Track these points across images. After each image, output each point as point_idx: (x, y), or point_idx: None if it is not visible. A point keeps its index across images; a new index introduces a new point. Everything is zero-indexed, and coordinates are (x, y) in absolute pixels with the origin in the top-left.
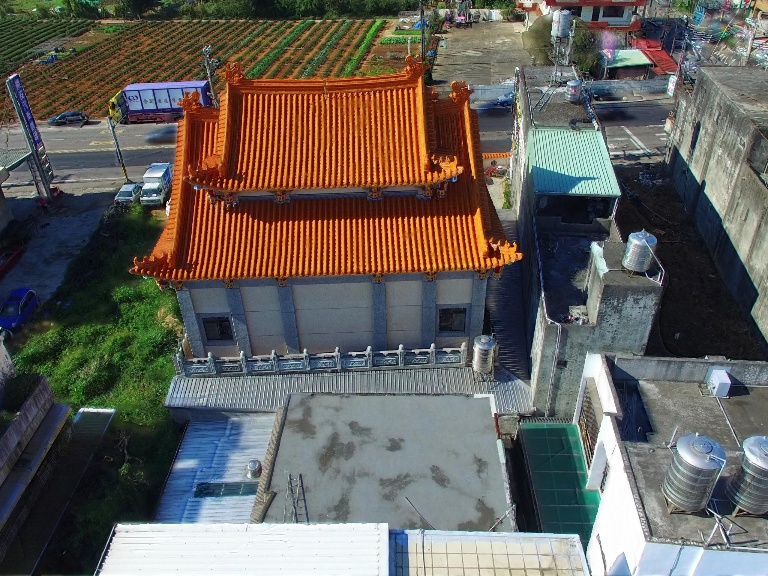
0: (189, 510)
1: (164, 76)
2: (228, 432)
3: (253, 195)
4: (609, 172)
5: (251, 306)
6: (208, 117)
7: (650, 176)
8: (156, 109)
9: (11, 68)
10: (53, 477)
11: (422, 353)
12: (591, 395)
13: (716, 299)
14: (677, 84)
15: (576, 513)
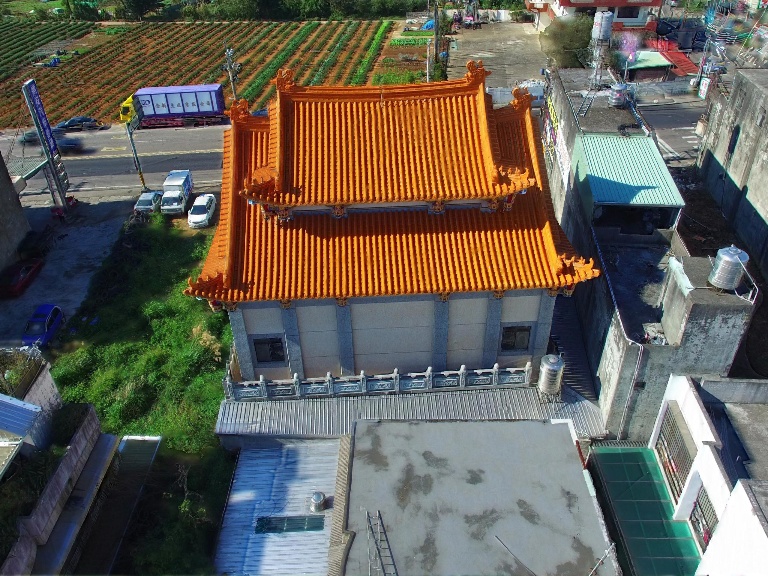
0: (252, 548)
1: (172, 79)
2: (284, 460)
3: (308, 209)
4: (668, 180)
5: (306, 326)
6: (256, 126)
7: (682, 180)
8: (168, 114)
9: (25, 73)
10: (103, 513)
11: (485, 373)
12: (676, 420)
13: (767, 309)
14: (710, 86)
15: (667, 546)
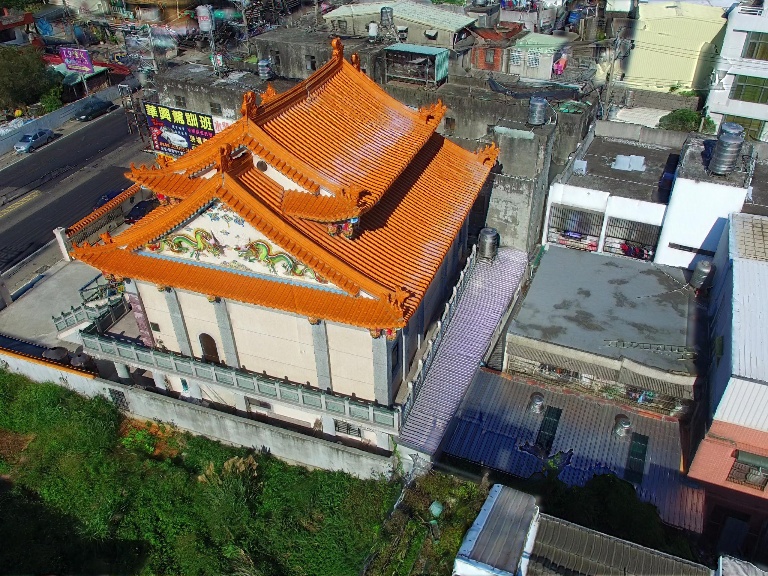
0: None
1: None
2: (476, 421)
3: None
4: None
5: None
6: (239, 170)
7: None
8: None
9: None
10: None
11: None
12: (568, 208)
13: None
14: (225, 61)
15: None
